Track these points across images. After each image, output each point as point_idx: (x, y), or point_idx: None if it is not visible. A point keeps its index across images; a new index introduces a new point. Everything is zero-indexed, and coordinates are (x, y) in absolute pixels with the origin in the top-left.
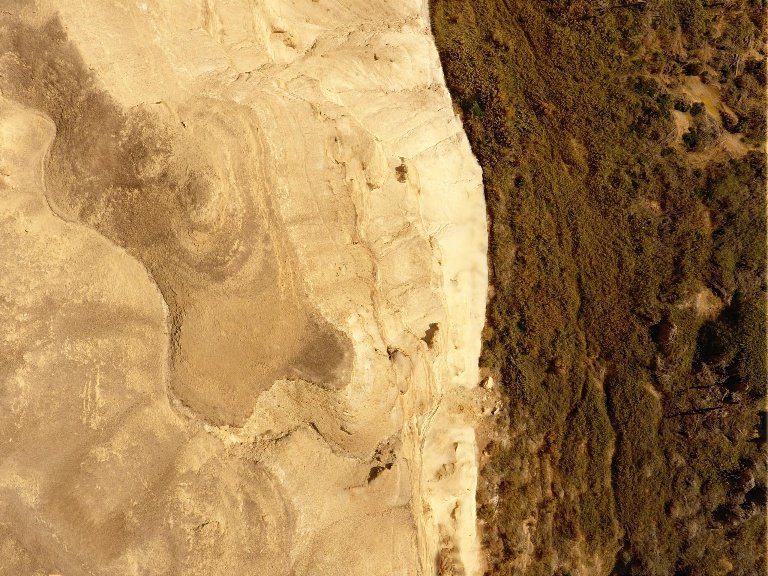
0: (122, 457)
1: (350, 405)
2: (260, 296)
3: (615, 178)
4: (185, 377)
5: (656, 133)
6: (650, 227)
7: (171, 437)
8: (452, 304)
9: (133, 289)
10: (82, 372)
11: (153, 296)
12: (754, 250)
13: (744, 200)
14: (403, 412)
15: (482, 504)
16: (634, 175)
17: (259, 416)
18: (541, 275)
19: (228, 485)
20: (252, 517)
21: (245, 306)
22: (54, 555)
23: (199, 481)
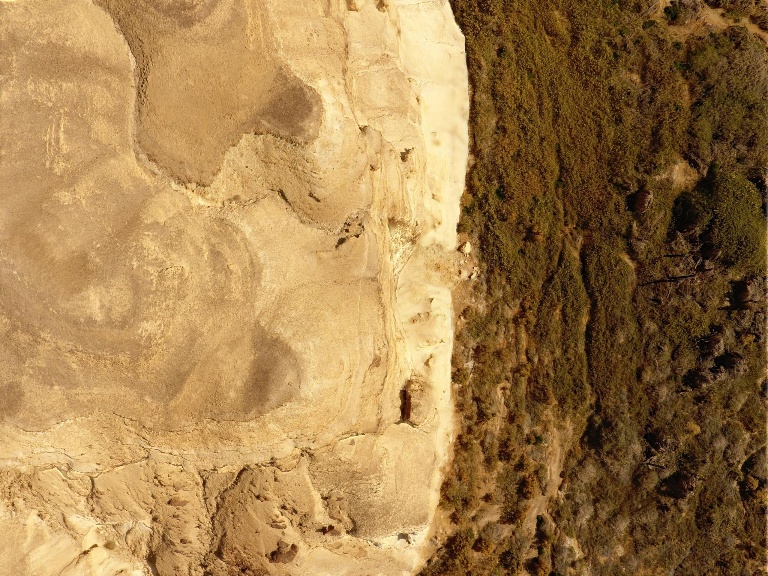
0: (86, 202)
1: (318, 164)
2: (228, 44)
3: (597, 49)
4: (151, 130)
5: (638, 5)
6: (630, 98)
7: (136, 190)
8: (430, 153)
9: (99, 37)
10: (45, 114)
11: (120, 47)
12: (731, 120)
13: (722, 72)
14: (373, 188)
15: (457, 368)
16: (615, 47)
17: (227, 177)
18: (521, 144)
19: (193, 237)
20: (217, 265)
21: (213, 54)
22: (14, 294)
23: (164, 232)
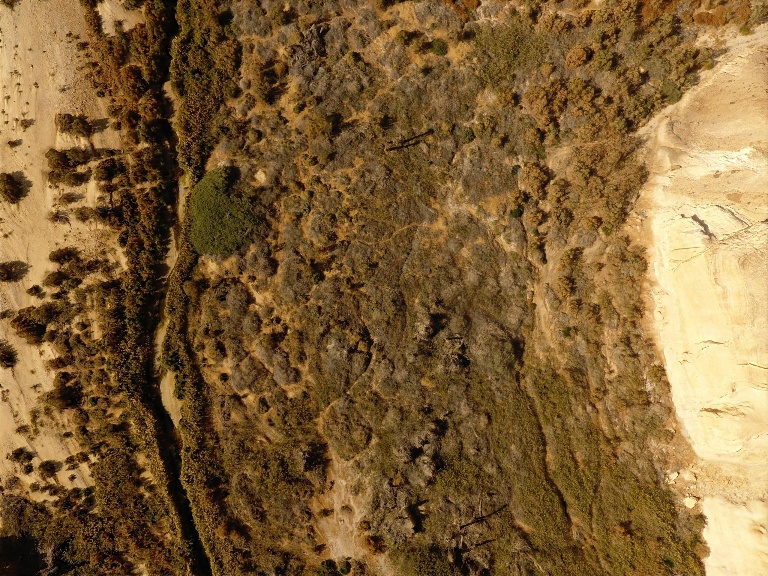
0: None
1: None
2: None
3: None
4: None
5: None
6: None
7: None
8: None
9: None
10: None
11: None
12: None
13: None
14: None
15: (661, 381)
16: None
17: None
18: None
19: None
20: None
21: None
22: None
23: None
